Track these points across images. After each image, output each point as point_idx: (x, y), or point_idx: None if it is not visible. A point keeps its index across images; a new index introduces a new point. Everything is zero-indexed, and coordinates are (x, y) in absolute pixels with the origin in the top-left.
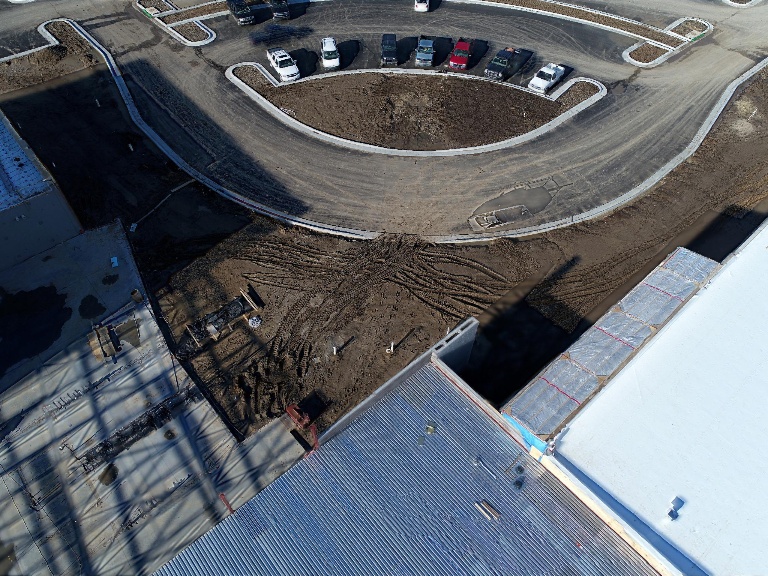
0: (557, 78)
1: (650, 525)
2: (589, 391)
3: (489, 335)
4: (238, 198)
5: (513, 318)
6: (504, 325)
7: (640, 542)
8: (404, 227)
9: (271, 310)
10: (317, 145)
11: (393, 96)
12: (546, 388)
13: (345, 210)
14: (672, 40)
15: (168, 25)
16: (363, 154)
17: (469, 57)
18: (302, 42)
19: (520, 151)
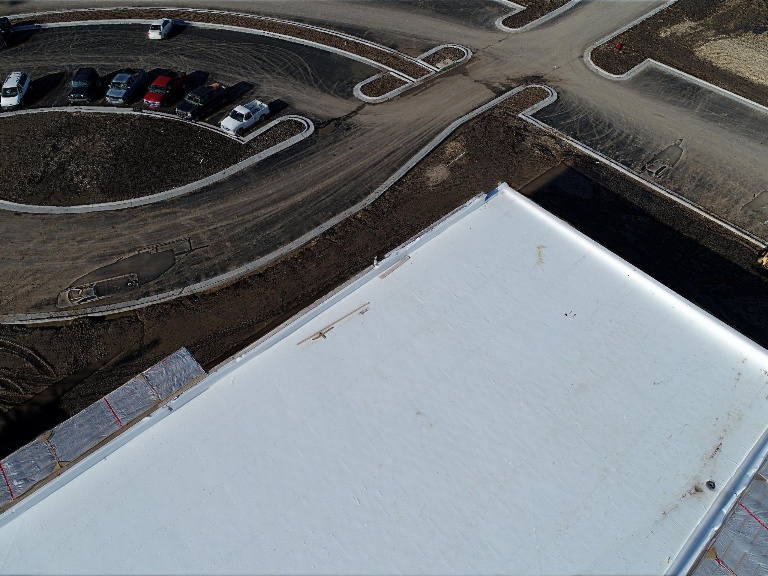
0: (257, 117)
1: None
2: None
3: None
4: None
5: (31, 424)
6: (15, 434)
7: None
8: None
9: None
10: None
11: (64, 140)
12: None
13: None
14: (418, 70)
15: None
16: None
17: (168, 93)
18: (2, 75)
19: (172, 205)
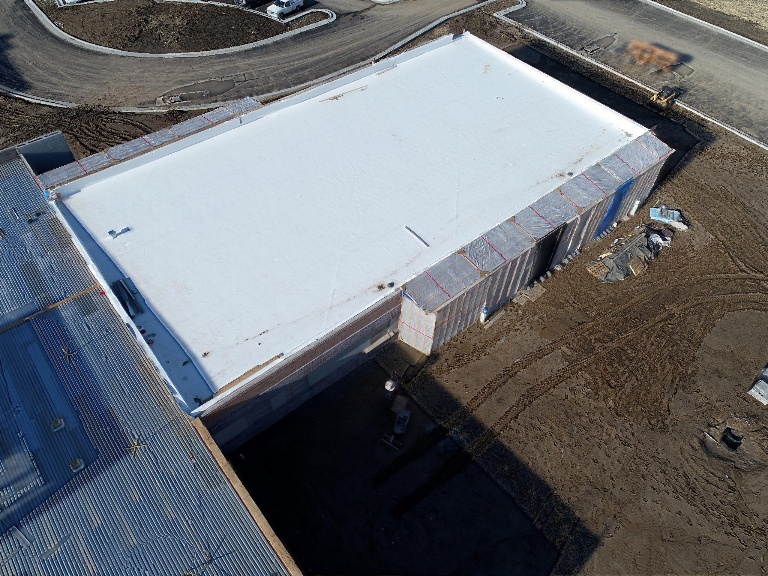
0: (294, 7)
1: (97, 240)
2: (99, 166)
3: None
4: None
5: None
6: None
7: (76, 244)
8: (102, 101)
9: None
10: (68, 47)
11: (152, 16)
12: (74, 166)
13: (62, 89)
14: None
15: None
16: (101, 54)
17: None
18: None
19: (232, 56)
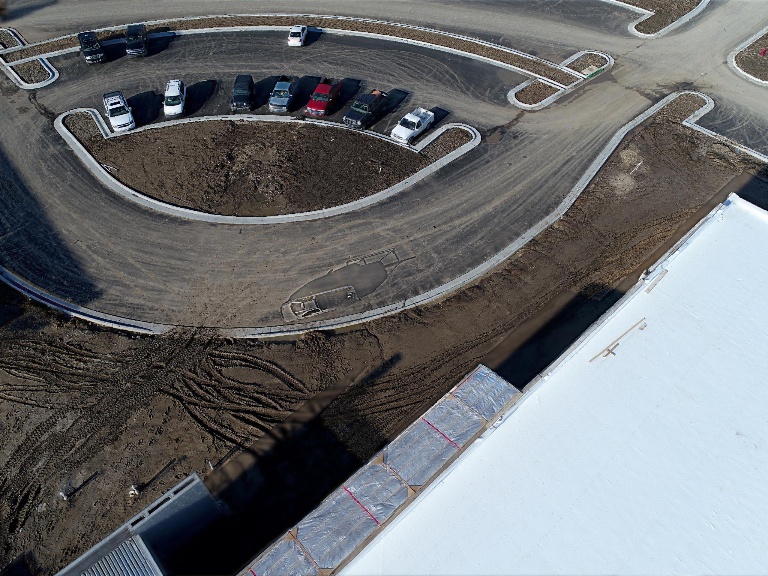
0: (425, 125)
1: None
2: None
3: (265, 467)
4: (17, 282)
5: (300, 442)
6: (286, 452)
7: None
8: (203, 317)
9: (5, 437)
10: (132, 211)
11: (236, 148)
12: None
13: (140, 296)
14: (566, 77)
15: (8, 64)
16: (182, 222)
17: (330, 101)
18: (152, 83)
19: (365, 216)
